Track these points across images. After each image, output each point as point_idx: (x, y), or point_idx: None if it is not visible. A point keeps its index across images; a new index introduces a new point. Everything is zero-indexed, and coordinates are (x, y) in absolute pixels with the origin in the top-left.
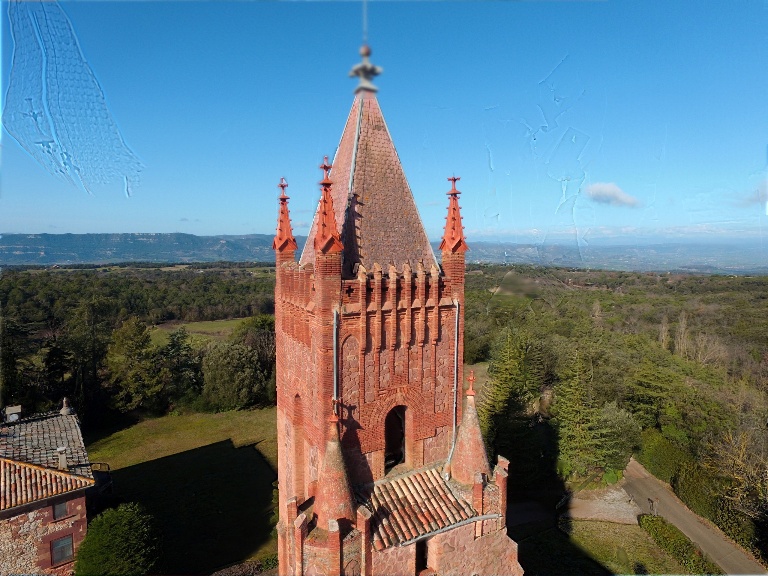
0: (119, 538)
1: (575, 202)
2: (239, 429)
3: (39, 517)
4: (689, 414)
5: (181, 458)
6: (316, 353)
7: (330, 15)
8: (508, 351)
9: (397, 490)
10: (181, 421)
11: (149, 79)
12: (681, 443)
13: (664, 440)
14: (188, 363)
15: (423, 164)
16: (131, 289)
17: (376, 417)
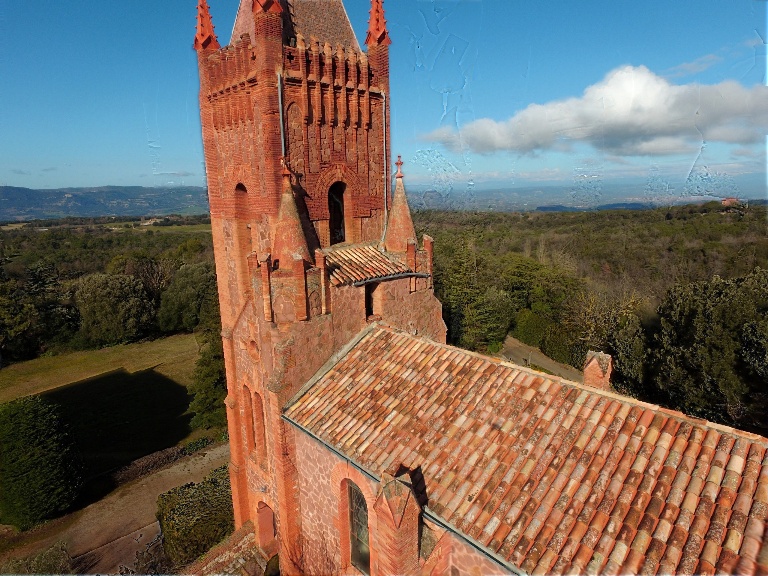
0: (24, 425)
1: (458, 107)
2: (131, 358)
3: None
4: (552, 289)
5: (67, 389)
6: (261, 121)
7: None
8: None
9: (343, 255)
10: (58, 360)
11: None
12: (546, 314)
13: (533, 314)
14: (57, 299)
15: None
16: None
17: (320, 188)
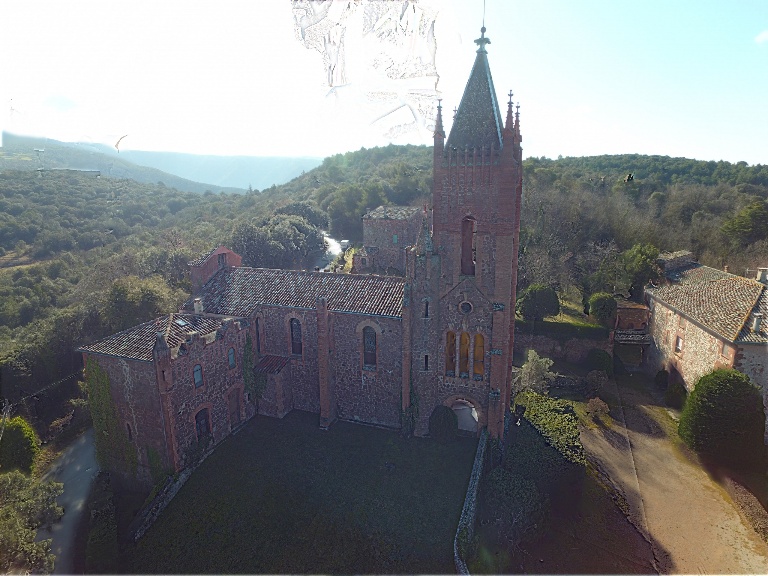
0: None
1: None
2: None
3: None
4: None
5: None
6: None
7: None
8: None
9: None
10: None
11: None
12: None
13: None
14: None
15: None
16: None
17: None
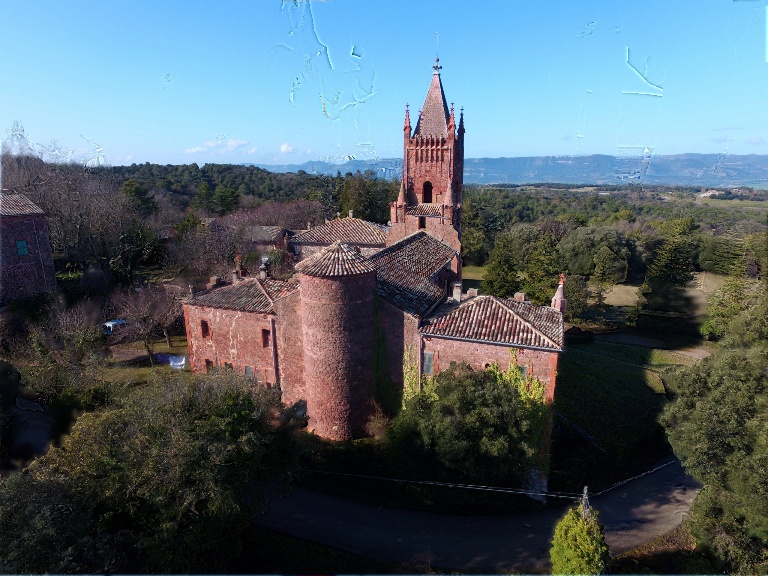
0: None
1: None
2: None
3: None
4: None
5: (472, 281)
6: None
7: (340, 98)
8: (679, 227)
9: None
10: None
11: (329, 107)
12: None
13: None
14: None
15: (650, 70)
16: (472, 182)
17: (420, 183)
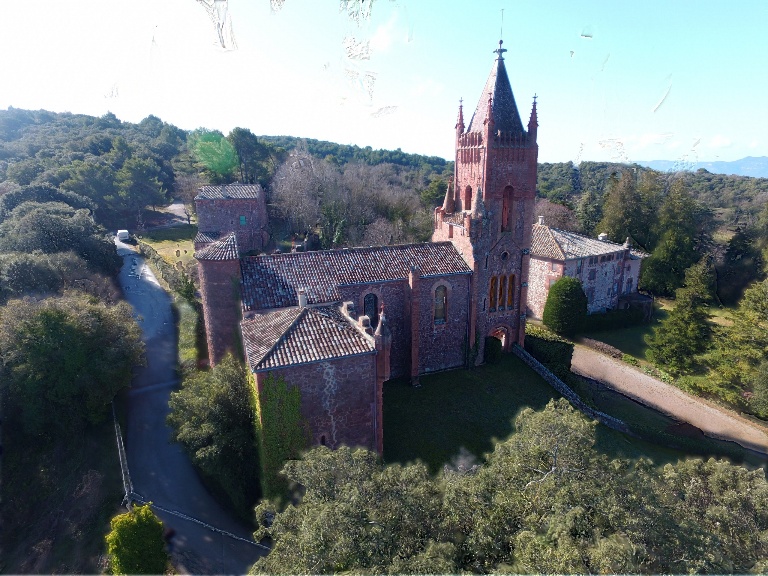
0: (558, 285)
1: None
2: None
3: (548, 265)
4: None
5: None
6: None
7: None
8: None
9: None
10: None
11: None
12: None
13: None
14: None
15: None
16: None
17: None
